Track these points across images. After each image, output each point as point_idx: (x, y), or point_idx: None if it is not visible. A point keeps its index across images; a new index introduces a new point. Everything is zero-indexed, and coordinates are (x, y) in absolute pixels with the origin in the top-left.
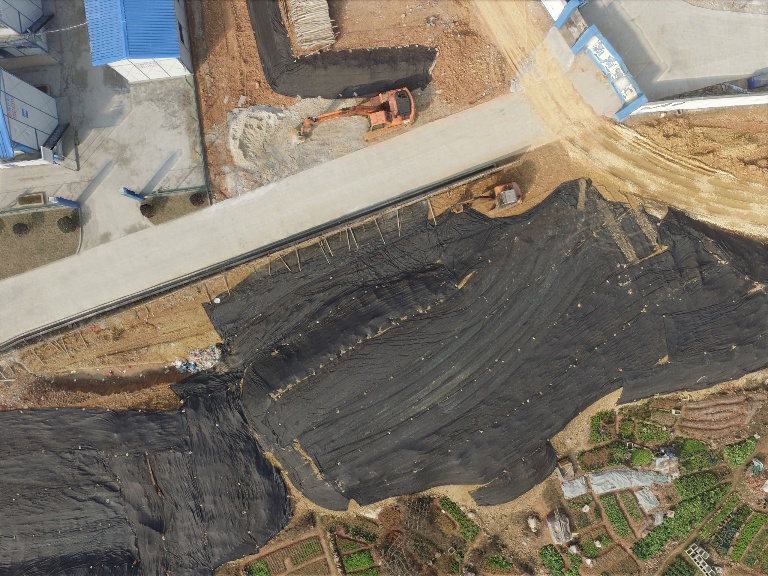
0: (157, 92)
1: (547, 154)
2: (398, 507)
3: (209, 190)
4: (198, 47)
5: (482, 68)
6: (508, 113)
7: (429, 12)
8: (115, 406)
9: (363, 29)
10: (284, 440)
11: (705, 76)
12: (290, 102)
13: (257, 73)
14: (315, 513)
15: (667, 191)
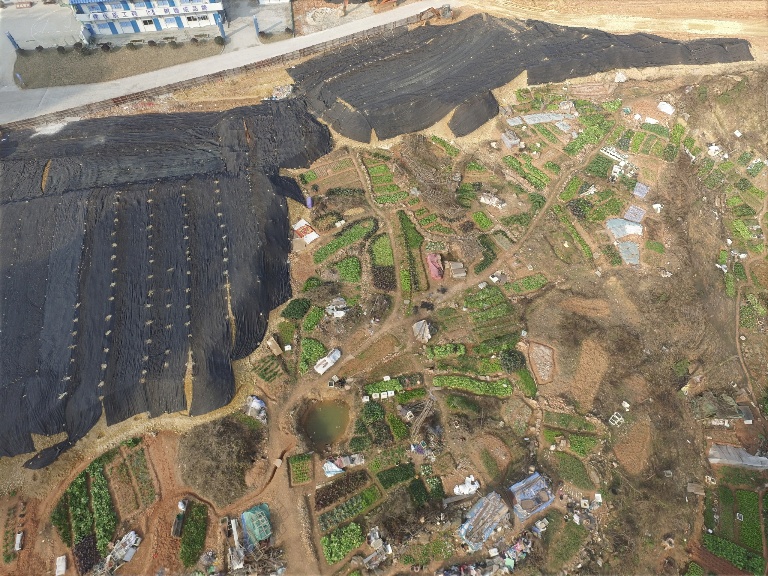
0: (272, 8)
1: (464, 8)
2: (403, 143)
3: (294, 32)
4: None
5: None
6: None
7: None
8: (225, 110)
9: None
10: (331, 102)
11: None
12: (337, 6)
13: (321, 2)
14: (348, 148)
15: (527, 17)
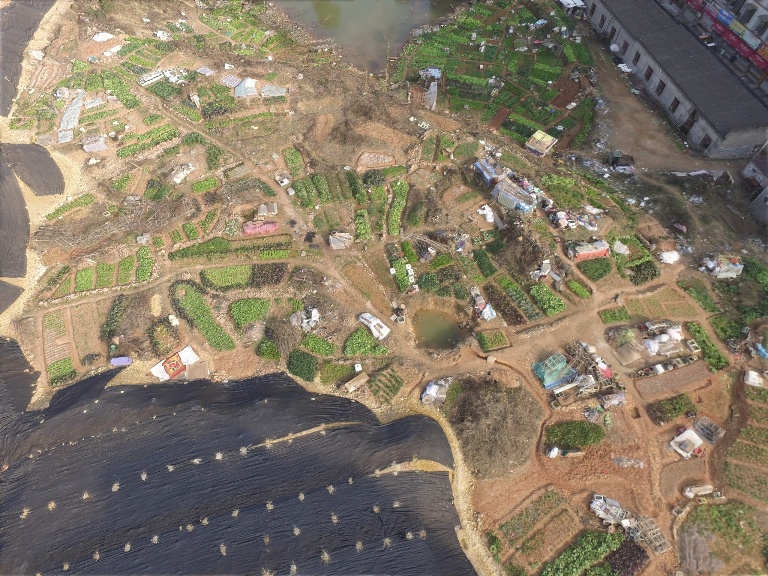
0: None
1: None
2: None
3: None
4: None
5: None
6: None
7: None
8: None
9: None
10: None
11: None
12: None
13: None
14: (18, 319)
15: None
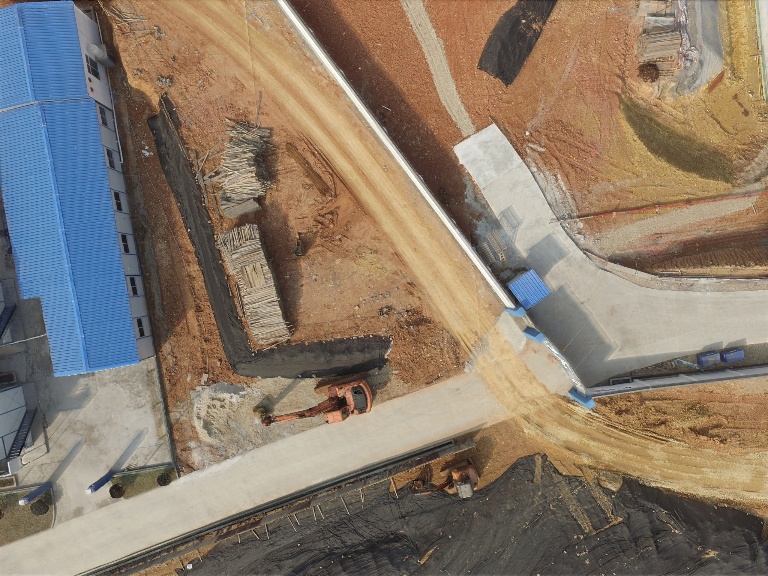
0: (121, 374)
1: (503, 431)
2: None
3: (176, 465)
4: (159, 328)
5: (436, 353)
6: (464, 392)
7: (382, 303)
8: None
9: (318, 321)
10: None
11: (655, 354)
12: (251, 381)
13: (218, 351)
14: None
15: (621, 460)
